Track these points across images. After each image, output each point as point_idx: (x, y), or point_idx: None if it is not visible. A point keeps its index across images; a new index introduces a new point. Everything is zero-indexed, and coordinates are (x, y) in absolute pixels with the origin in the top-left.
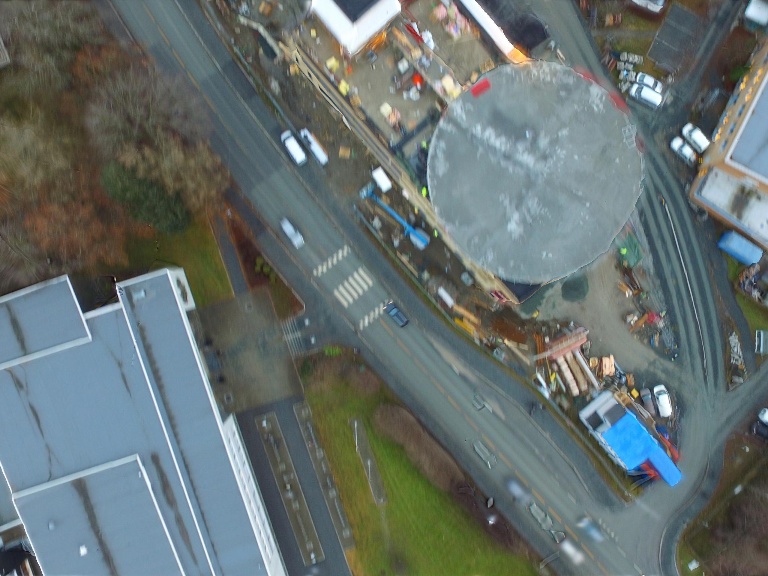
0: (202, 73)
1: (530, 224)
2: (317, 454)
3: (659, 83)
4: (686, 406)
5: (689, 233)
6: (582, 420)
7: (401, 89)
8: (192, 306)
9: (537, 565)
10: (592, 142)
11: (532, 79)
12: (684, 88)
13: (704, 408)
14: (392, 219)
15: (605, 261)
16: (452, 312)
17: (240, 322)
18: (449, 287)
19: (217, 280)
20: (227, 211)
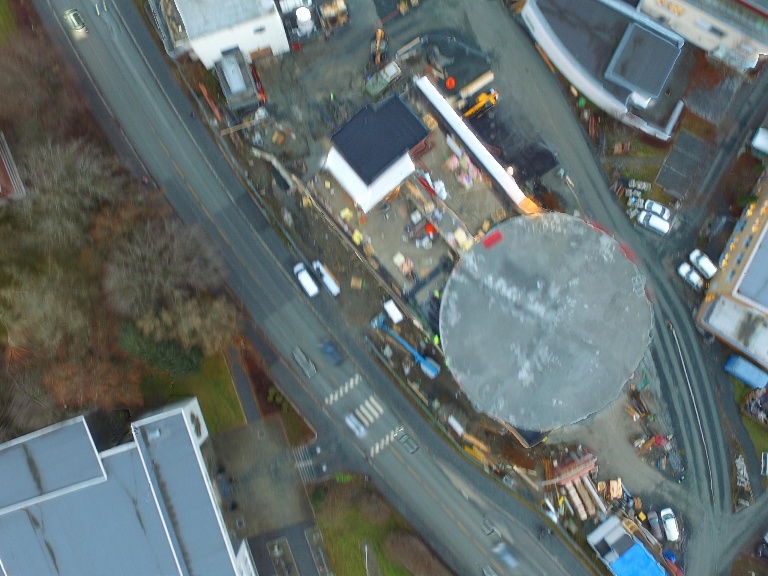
0: (216, 206)
1: (541, 372)
2: None
3: (667, 210)
4: (693, 528)
5: (696, 357)
6: (590, 544)
7: (414, 238)
8: (205, 436)
9: None
10: (602, 291)
11: (543, 230)
12: (691, 213)
13: (710, 530)
14: (403, 347)
15: None
16: (462, 440)
17: (252, 449)
18: (459, 415)
19: (230, 408)
20: (240, 342)
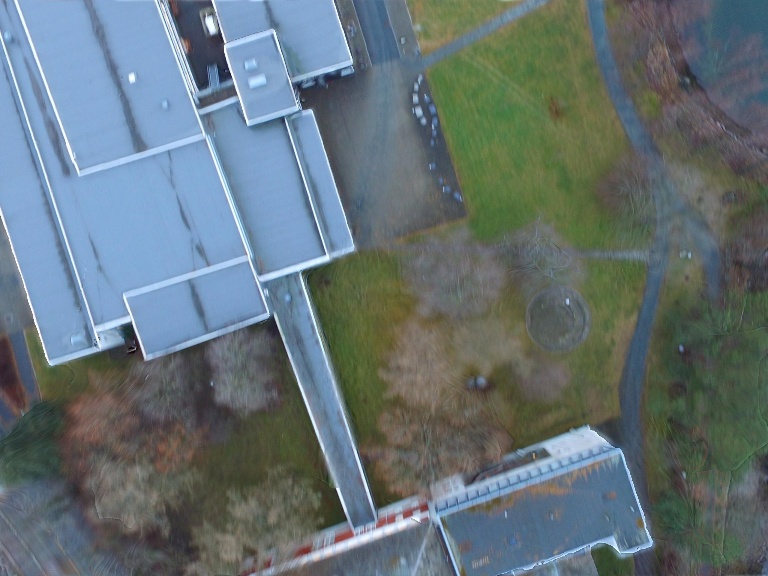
0: (52, 553)
1: None
2: None
3: None
4: None
5: None
6: None
7: None
8: None
9: None
10: None
11: None
12: None
13: None
14: None
15: None
16: None
17: (19, 303)
18: None
19: None
20: None
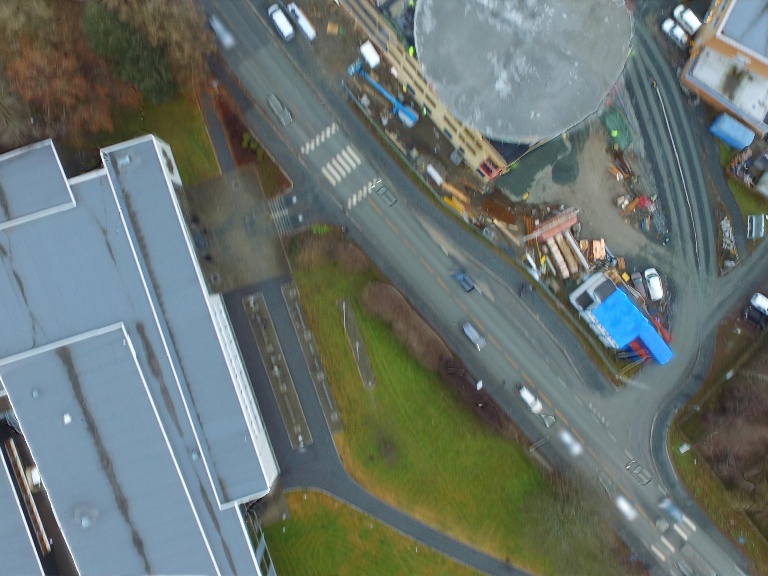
0: None
1: (518, 83)
2: (305, 336)
3: None
4: (677, 291)
5: (680, 116)
6: (572, 303)
7: None
8: (178, 182)
9: (527, 449)
10: (581, 0)
11: None
12: None
13: (696, 293)
14: (380, 97)
15: (596, 144)
16: (441, 190)
17: (227, 200)
18: (438, 166)
19: (204, 158)
20: (214, 86)
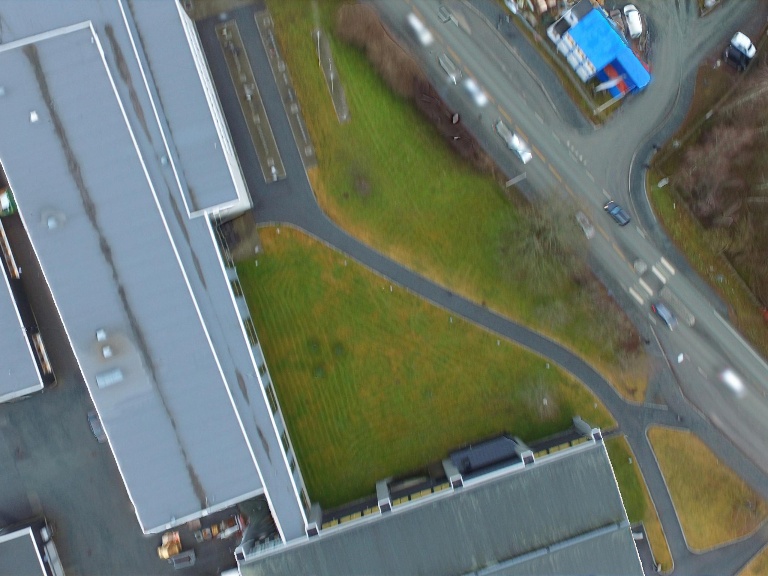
0: None
1: None
2: (279, 67)
3: None
4: (657, 31)
5: None
6: (550, 37)
7: None
8: None
9: (503, 184)
10: None
11: None
12: None
13: (675, 33)
14: None
15: None
16: None
17: None
18: None
19: None
20: None
